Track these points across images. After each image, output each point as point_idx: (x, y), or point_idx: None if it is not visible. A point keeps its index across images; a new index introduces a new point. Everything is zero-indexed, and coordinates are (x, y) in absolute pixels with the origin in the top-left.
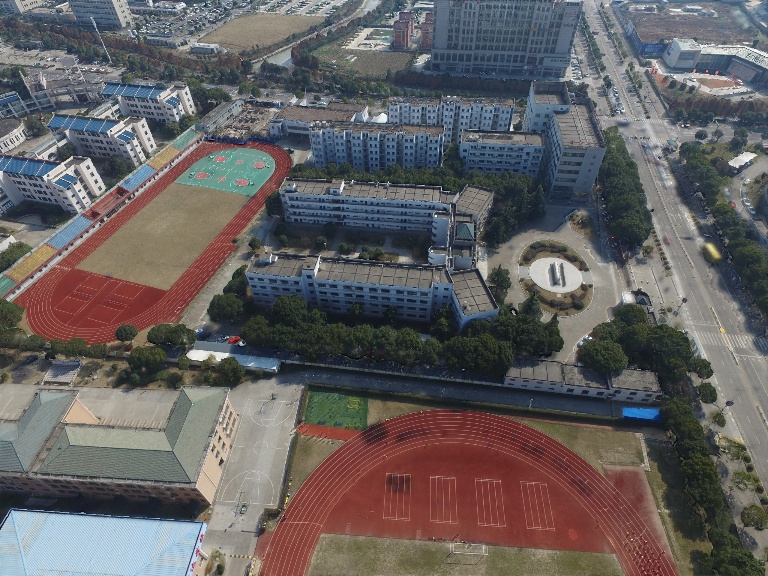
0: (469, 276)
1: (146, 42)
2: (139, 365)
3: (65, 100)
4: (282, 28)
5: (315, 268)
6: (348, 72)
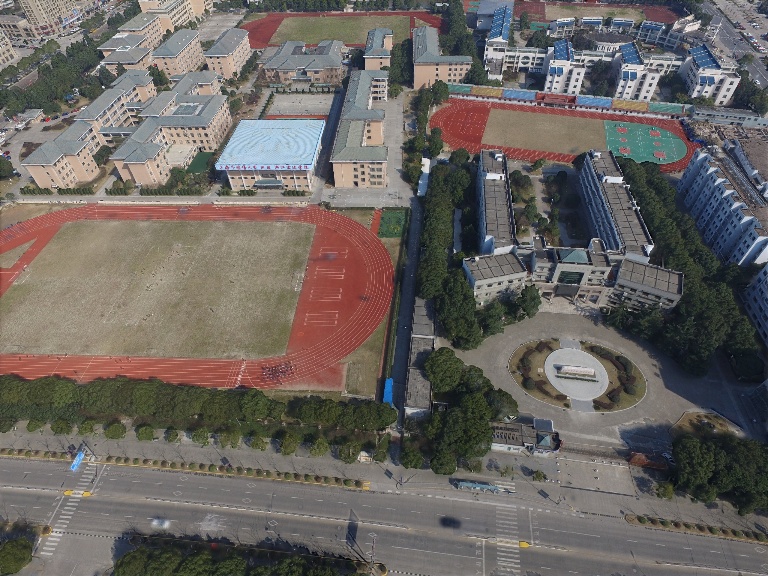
0: (516, 266)
1: None
2: None
3: None
4: None
5: (490, 174)
6: None
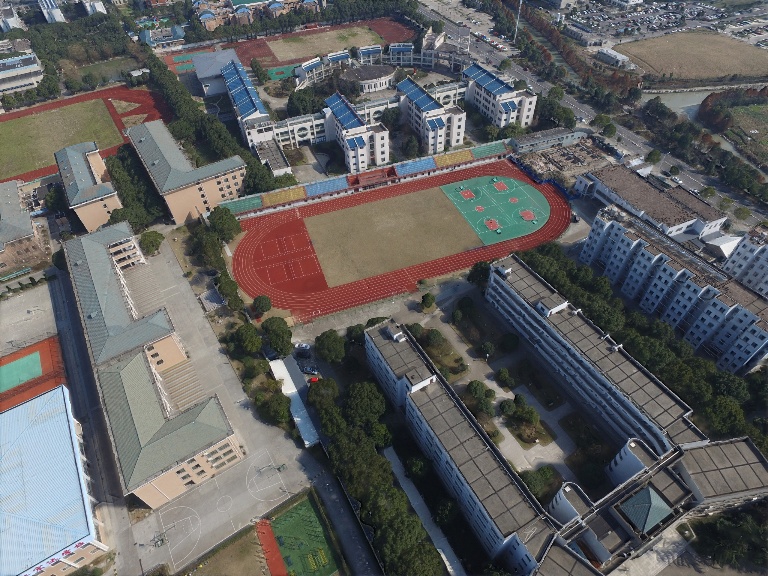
0: (582, 574)
1: (564, 30)
2: (241, 339)
3: (446, 64)
4: (728, 62)
5: (416, 385)
6: (760, 154)
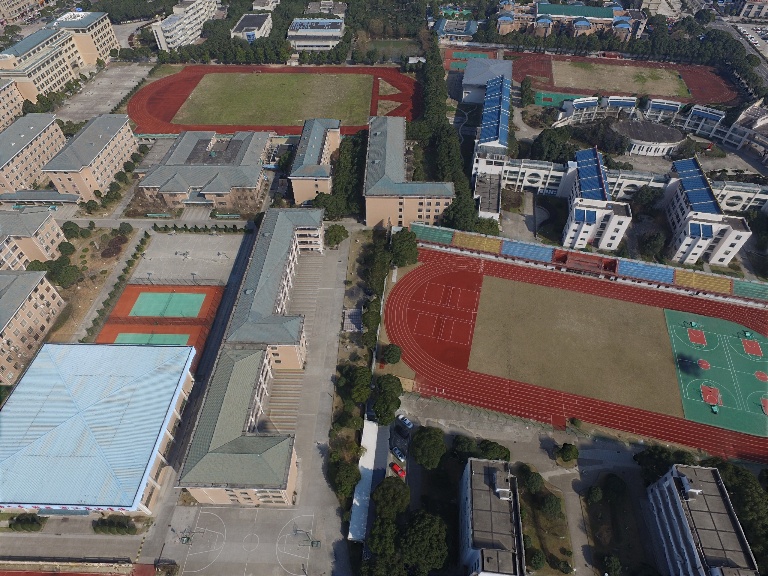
0: None
1: None
2: None
3: (759, 150)
4: None
5: (488, 573)
6: None
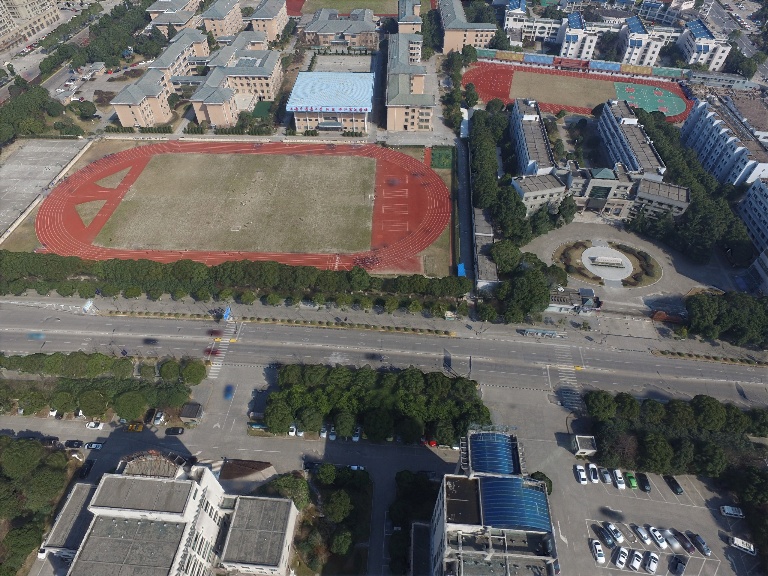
0: (556, 183)
1: None
2: None
3: None
4: None
5: (527, 115)
6: None
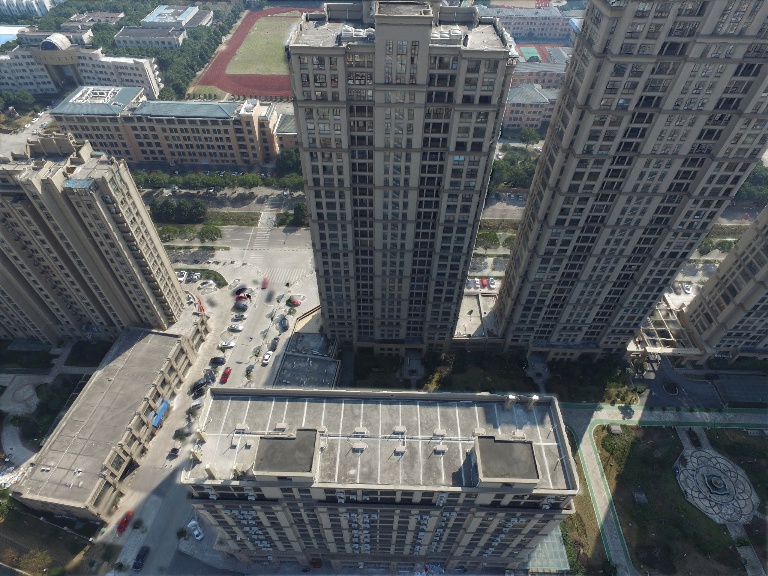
0: None
1: None
2: None
3: None
4: None
5: None
6: None
